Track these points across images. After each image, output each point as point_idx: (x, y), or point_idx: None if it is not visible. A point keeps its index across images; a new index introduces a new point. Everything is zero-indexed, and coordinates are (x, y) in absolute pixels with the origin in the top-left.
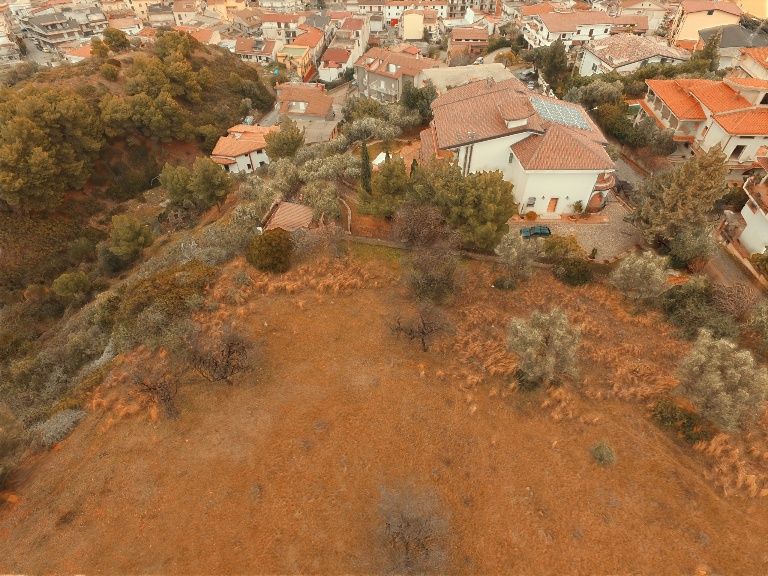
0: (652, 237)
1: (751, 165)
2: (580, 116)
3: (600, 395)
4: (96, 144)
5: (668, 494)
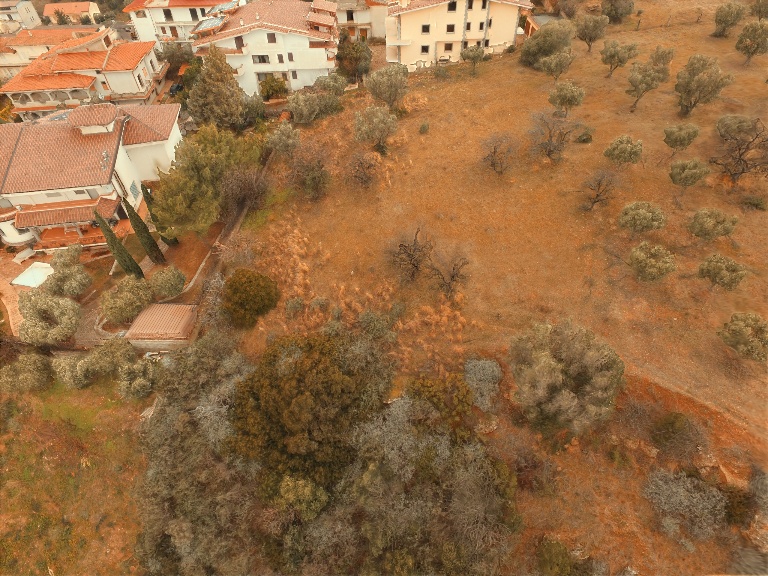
0: (241, 118)
1: (153, 83)
2: None
3: None
4: None
5: (435, 119)
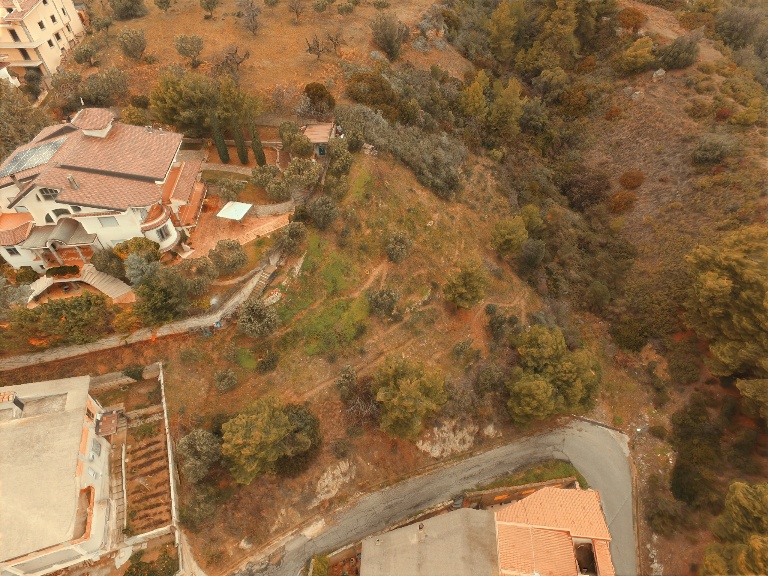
0: None
1: None
2: (6, 167)
3: (174, 62)
4: (749, 389)
5: (172, 49)
